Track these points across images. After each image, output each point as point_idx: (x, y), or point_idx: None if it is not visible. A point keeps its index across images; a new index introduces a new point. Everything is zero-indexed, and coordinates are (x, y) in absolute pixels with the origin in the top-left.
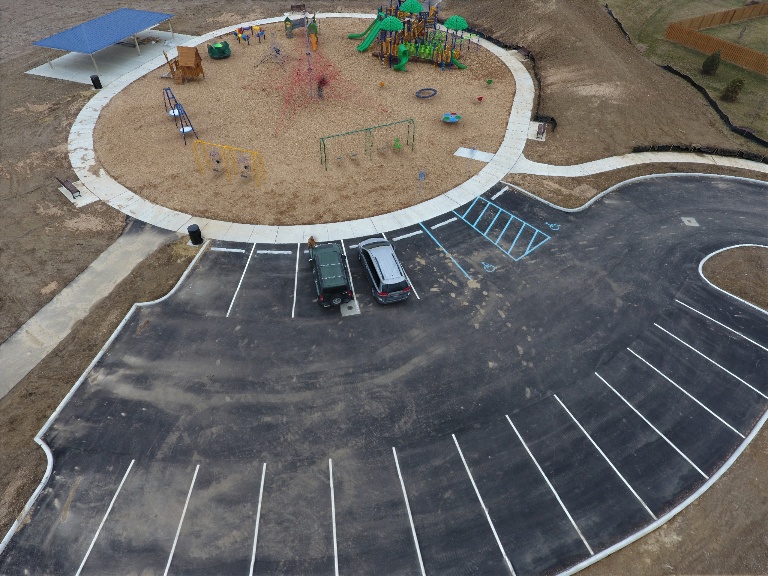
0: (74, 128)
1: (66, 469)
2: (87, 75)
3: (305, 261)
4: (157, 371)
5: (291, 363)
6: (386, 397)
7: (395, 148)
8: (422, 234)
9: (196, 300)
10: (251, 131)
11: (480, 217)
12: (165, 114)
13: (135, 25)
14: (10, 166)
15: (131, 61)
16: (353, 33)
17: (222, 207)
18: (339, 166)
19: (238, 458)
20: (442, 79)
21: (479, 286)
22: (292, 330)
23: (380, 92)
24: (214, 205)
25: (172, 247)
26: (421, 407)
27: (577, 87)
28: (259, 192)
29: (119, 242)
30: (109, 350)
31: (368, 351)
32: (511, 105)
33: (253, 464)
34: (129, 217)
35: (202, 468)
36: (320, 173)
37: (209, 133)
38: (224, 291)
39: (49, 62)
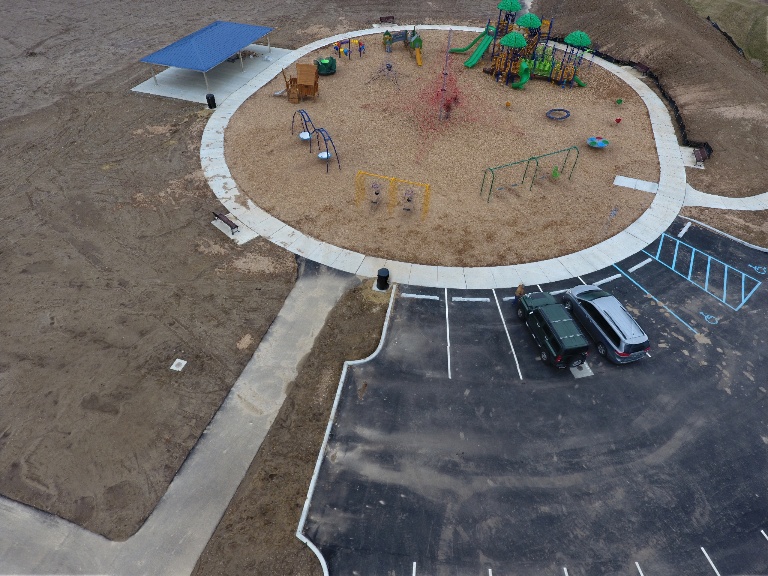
0: (203, 152)
1: (344, 575)
2: (196, 93)
3: (508, 310)
4: (399, 447)
5: (543, 437)
6: (667, 481)
7: (549, 176)
8: (622, 278)
9: (409, 358)
10: (390, 156)
11: (675, 258)
12: (292, 137)
13: (240, 40)
14: (152, 196)
15: (235, 77)
16: (452, 47)
17: (394, 245)
18: (498, 197)
19: (532, 560)
20: (565, 98)
21: (709, 341)
22: (528, 395)
23: (507, 112)
24: (384, 243)
25: (360, 293)
26: (711, 495)
27: (718, 108)
28: (426, 227)
29: (299, 286)
30: (337, 420)
31: (622, 422)
32: (651, 127)
33: (552, 569)
34: (298, 256)
35: (496, 574)
36: (482, 205)
37: (346, 159)
38: (435, 347)
39: (155, 79)
